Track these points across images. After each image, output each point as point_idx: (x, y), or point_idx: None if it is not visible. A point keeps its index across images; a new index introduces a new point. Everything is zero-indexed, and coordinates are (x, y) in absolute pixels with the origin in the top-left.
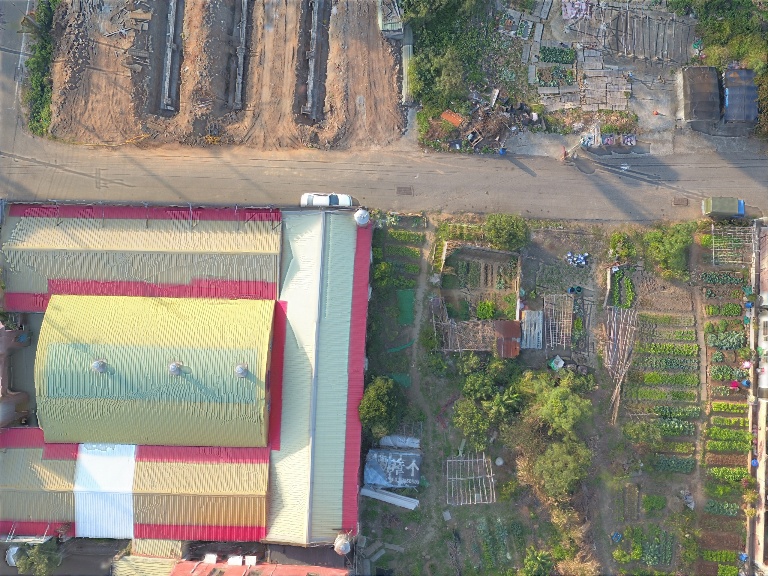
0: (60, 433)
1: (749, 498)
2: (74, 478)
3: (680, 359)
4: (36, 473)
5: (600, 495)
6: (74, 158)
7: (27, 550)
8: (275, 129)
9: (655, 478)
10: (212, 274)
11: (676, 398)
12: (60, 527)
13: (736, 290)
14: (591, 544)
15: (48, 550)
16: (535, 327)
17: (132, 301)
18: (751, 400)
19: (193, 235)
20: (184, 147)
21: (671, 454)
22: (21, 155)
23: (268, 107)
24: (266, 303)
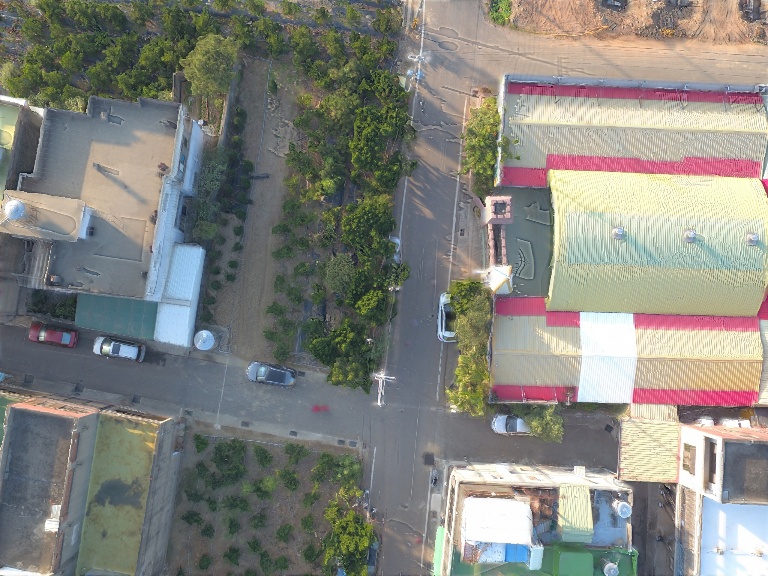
0: (563, 301)
1: None
2: (581, 343)
3: None
4: (544, 339)
5: None
6: (536, 47)
7: (543, 411)
8: (724, 24)
9: None
10: (689, 155)
11: None
12: (568, 390)
13: None
14: None
15: (559, 412)
16: None
17: (630, 176)
18: None
19: (683, 115)
20: (640, 39)
21: None
22: (484, 43)
23: (716, 4)
24: (753, 180)
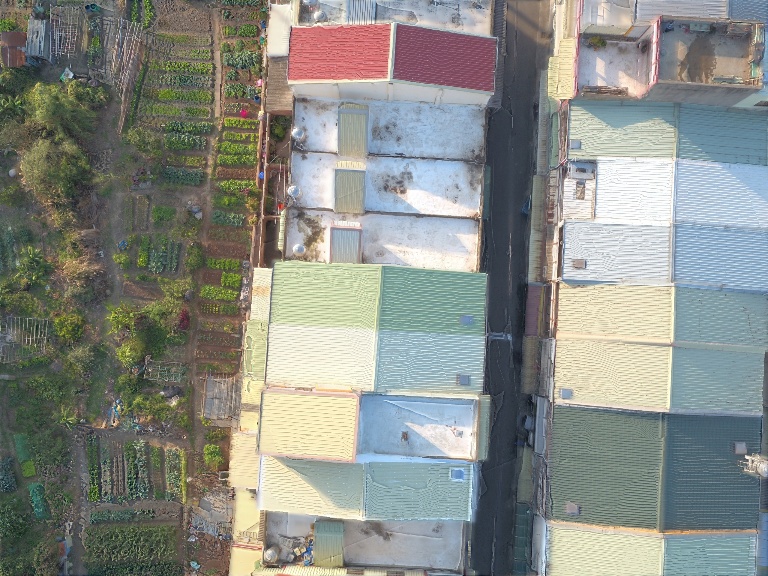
0: None
1: (249, 206)
2: None
3: (194, 76)
4: None
5: (110, 206)
6: None
7: None
8: None
9: (160, 187)
10: None
11: (189, 114)
12: None
13: (254, 12)
14: (93, 249)
15: None
16: (37, 35)
17: None
18: (260, 115)
19: None
20: None
21: (181, 167)
22: None
23: None
24: None
